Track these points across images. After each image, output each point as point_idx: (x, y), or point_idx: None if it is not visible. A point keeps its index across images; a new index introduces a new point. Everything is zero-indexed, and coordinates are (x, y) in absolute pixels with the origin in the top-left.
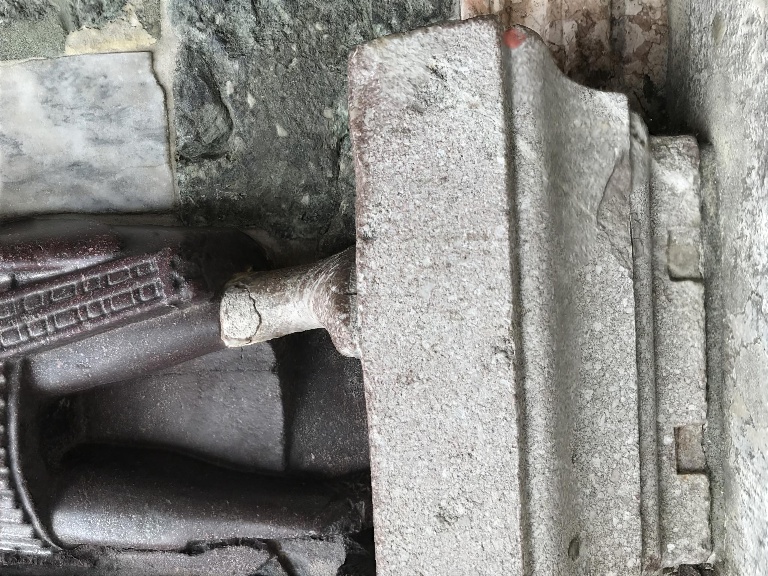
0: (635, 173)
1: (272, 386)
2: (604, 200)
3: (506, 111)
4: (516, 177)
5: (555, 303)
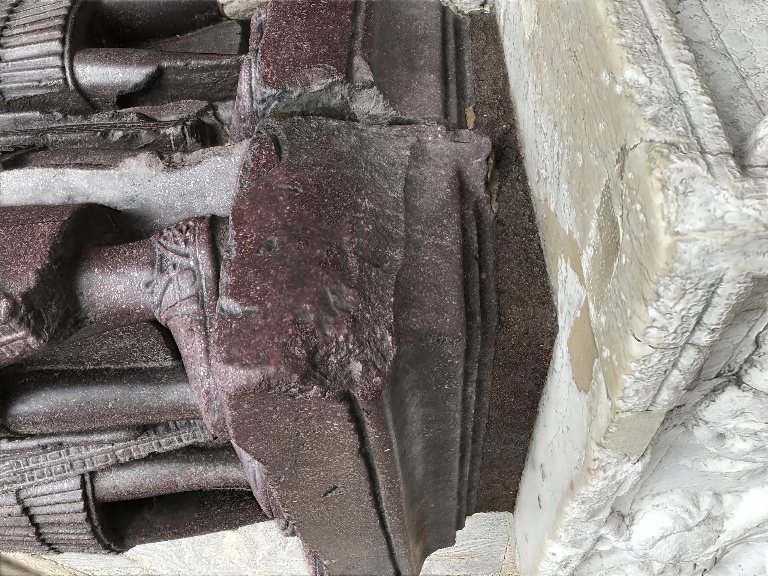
0: None
1: (236, 39)
2: None
3: None
4: None
5: None
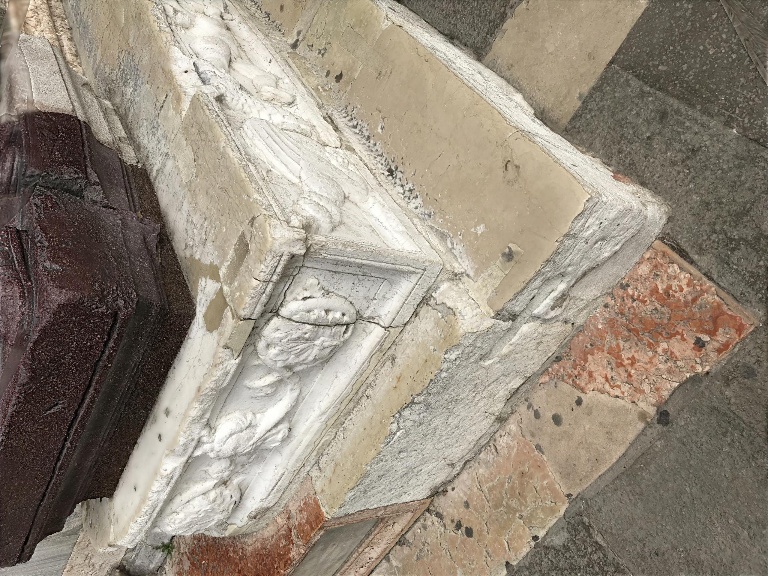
0: None
1: None
2: None
3: None
4: None
5: None
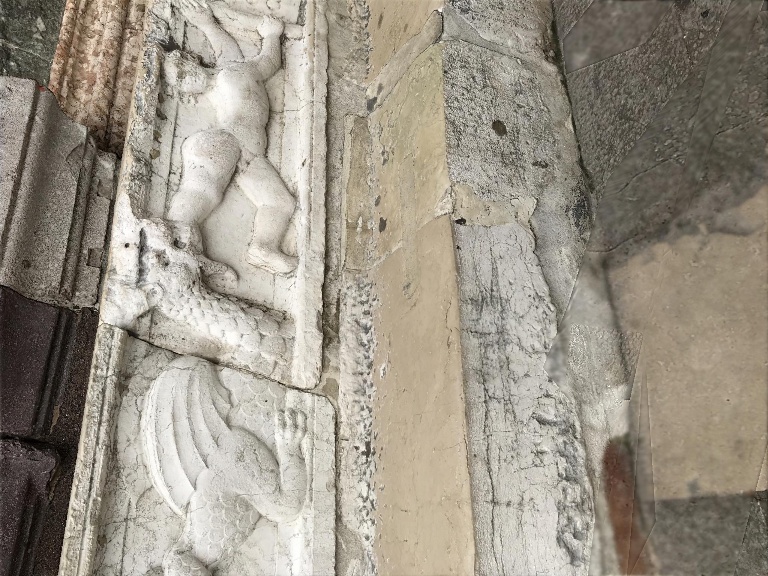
0: (87, 153)
1: None
2: (71, 155)
3: (33, 106)
4: (32, 127)
5: (39, 171)
